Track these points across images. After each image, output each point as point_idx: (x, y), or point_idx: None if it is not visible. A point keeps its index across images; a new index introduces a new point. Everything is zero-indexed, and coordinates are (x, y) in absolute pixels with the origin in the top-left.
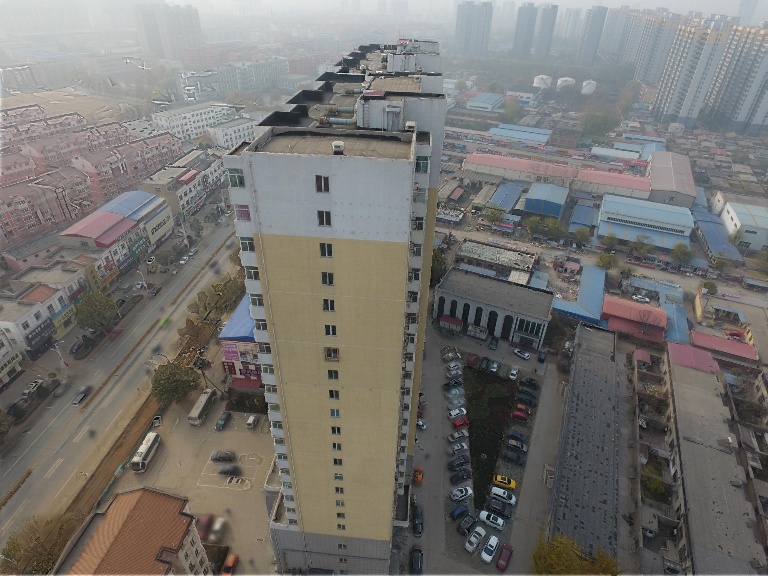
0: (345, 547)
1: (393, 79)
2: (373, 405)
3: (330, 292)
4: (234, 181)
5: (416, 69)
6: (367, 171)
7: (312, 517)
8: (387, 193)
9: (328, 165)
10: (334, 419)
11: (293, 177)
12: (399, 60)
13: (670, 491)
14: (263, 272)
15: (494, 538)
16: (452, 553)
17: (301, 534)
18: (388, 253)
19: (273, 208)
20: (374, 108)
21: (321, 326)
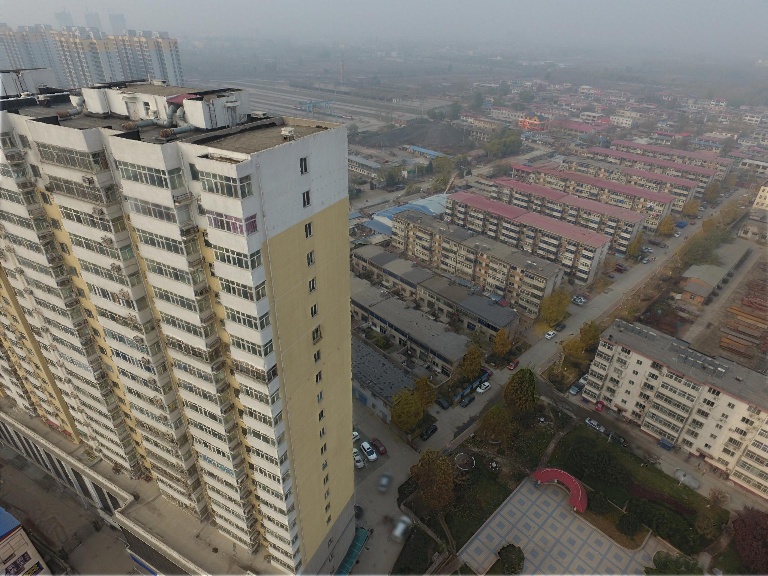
0: (331, 541)
1: (133, 88)
2: (340, 363)
3: (313, 271)
4: (243, 191)
5: (39, 87)
6: (327, 142)
7: (311, 538)
8: (337, 157)
9: (307, 146)
10: (320, 404)
11: (287, 167)
12: (9, 80)
13: (387, 339)
14: (270, 283)
15: (364, 444)
16: (357, 480)
17: (306, 570)
18: (340, 211)
19: (274, 206)
20: (216, 107)
21: (309, 311)
